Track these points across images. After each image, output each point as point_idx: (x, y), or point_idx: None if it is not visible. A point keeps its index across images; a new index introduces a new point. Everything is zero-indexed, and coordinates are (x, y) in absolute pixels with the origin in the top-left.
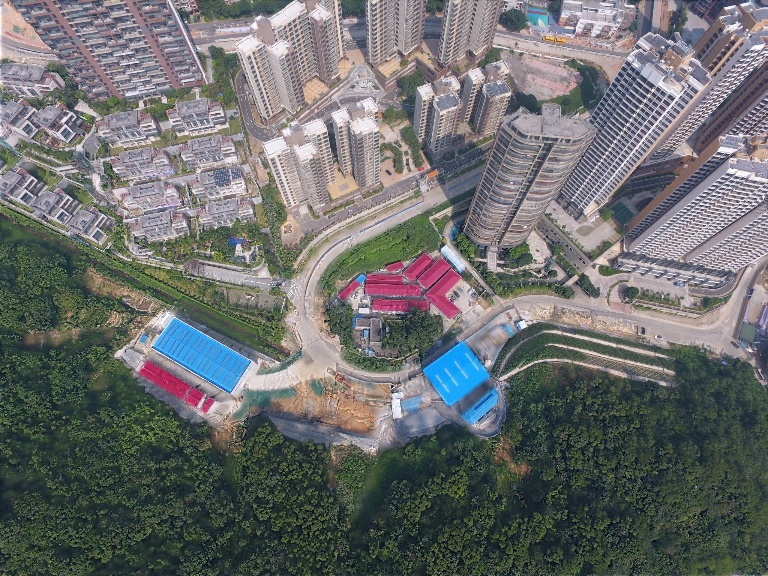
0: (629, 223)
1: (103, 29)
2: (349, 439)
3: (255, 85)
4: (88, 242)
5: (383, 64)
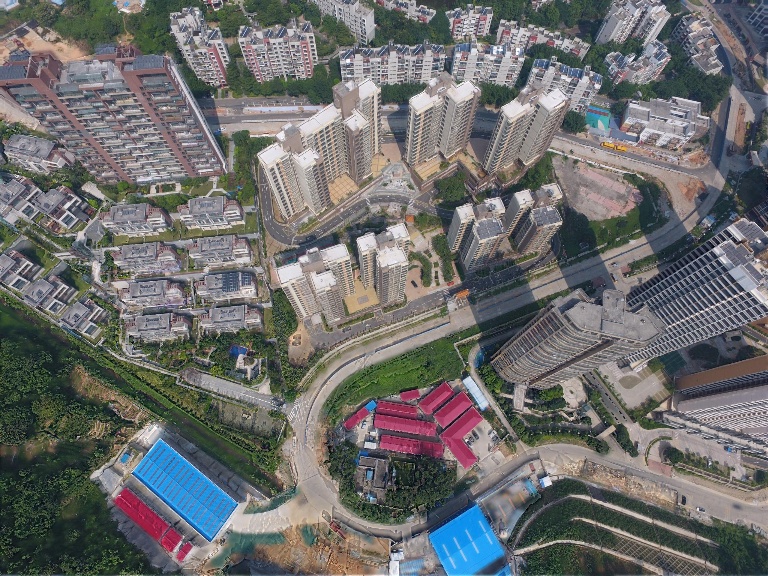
0: (681, 379)
1: (115, 124)
2: None
3: (276, 191)
4: (80, 334)
5: (421, 164)
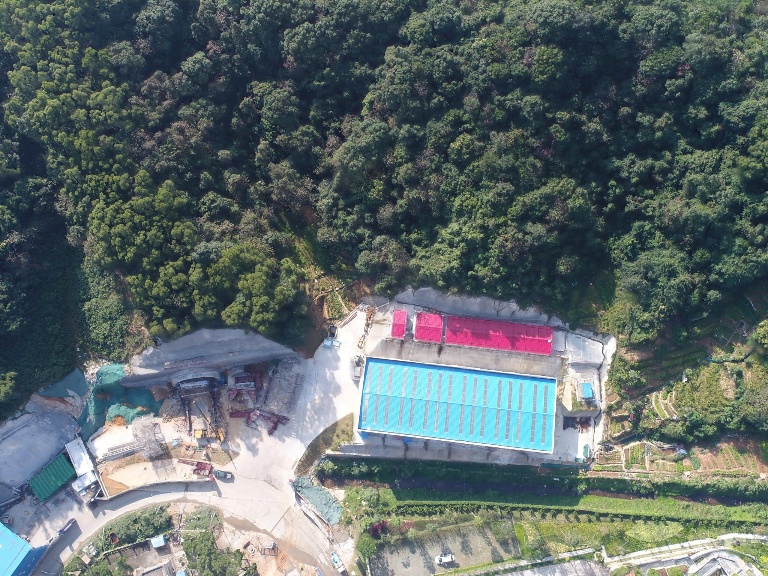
0: None
1: None
2: (136, 369)
3: None
4: None
5: None
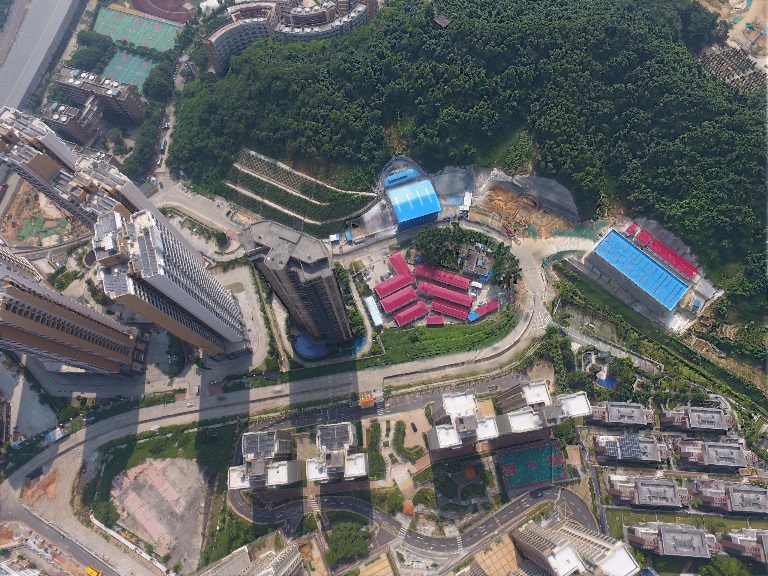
0: None
1: None
2: (514, 180)
3: None
4: None
5: None
